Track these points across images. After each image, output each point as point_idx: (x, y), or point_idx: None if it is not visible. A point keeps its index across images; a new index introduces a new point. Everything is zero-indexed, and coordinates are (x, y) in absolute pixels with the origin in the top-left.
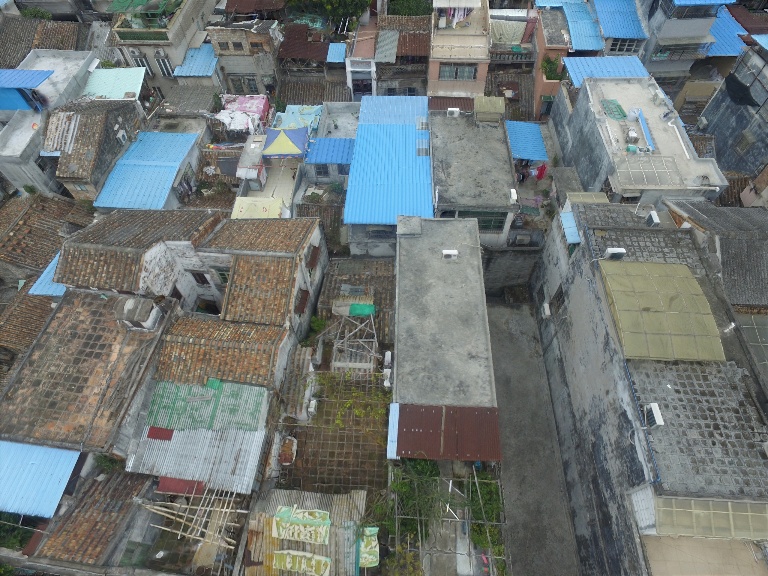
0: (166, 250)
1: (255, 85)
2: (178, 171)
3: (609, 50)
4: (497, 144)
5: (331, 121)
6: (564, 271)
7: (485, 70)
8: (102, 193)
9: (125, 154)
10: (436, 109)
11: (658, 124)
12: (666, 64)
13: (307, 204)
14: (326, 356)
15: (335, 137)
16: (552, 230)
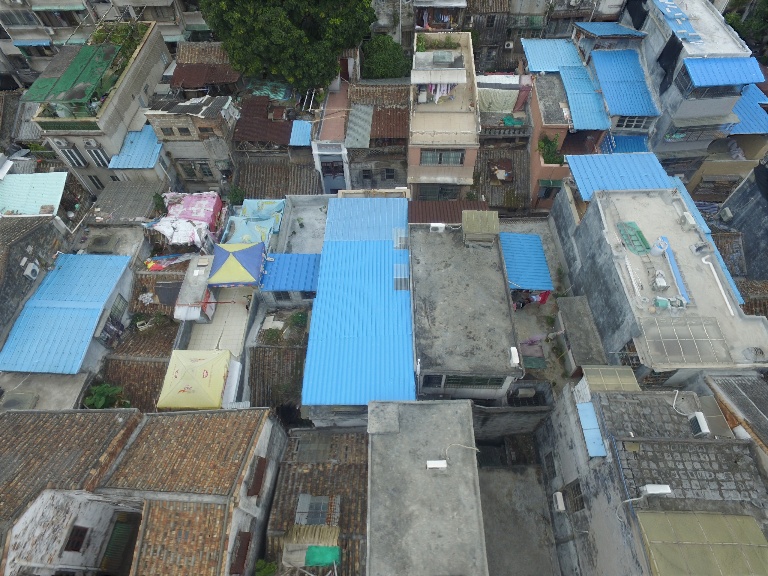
0: (54, 494)
1: (209, 169)
2: (102, 313)
3: (615, 126)
4: (491, 272)
5: (296, 217)
6: (582, 468)
7: (473, 155)
8: (4, 350)
9: (37, 290)
10: (417, 219)
11: (689, 260)
12: (681, 143)
13: (263, 346)
14: None
15: (300, 239)
16: (563, 398)
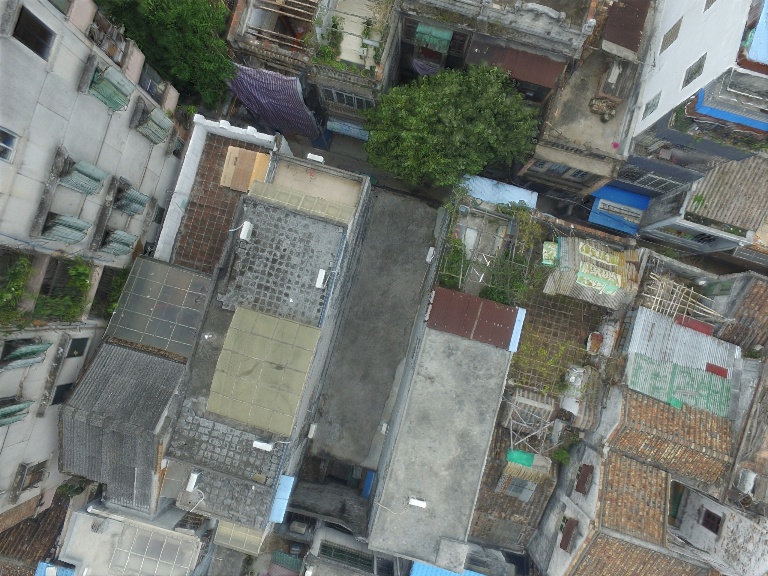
0: (743, 574)
1: None
2: None
3: None
4: None
5: None
6: None
7: None
8: None
9: None
10: None
11: None
12: None
13: None
14: (550, 426)
15: None
16: None
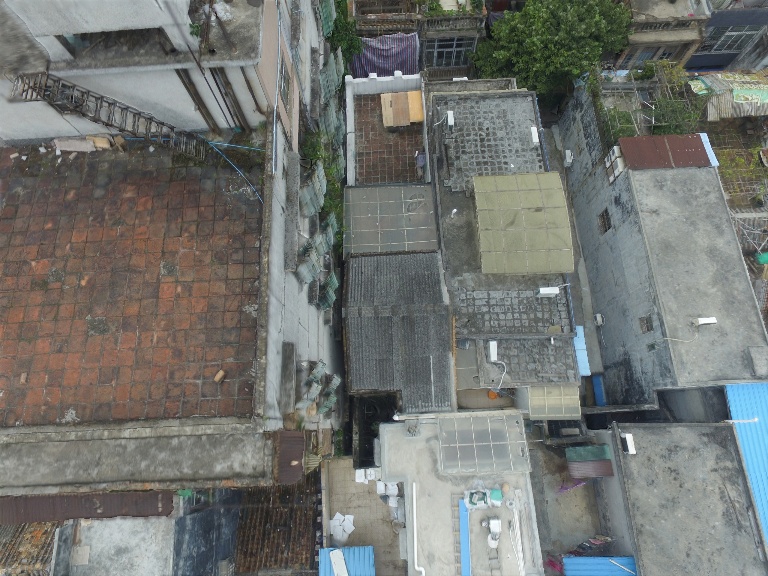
0: None
1: None
2: None
3: None
4: None
5: None
6: None
7: None
8: None
9: None
10: None
11: (440, 575)
12: None
13: None
14: None
15: None
16: None
